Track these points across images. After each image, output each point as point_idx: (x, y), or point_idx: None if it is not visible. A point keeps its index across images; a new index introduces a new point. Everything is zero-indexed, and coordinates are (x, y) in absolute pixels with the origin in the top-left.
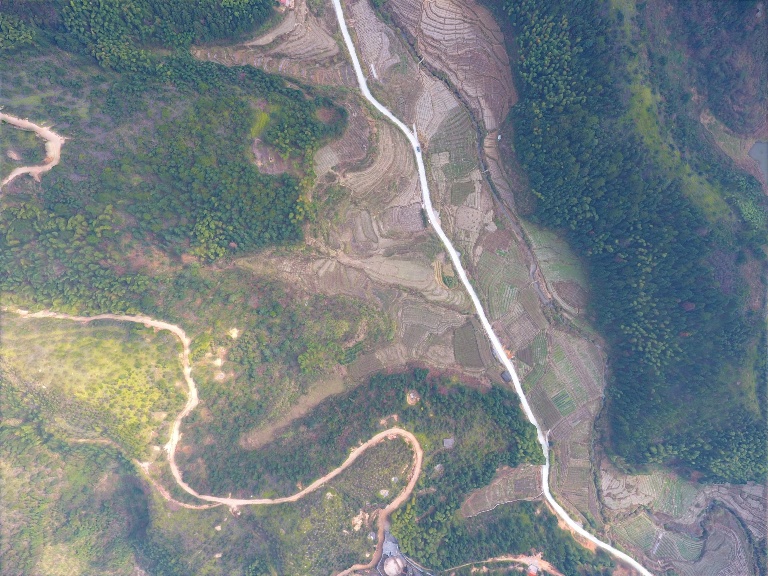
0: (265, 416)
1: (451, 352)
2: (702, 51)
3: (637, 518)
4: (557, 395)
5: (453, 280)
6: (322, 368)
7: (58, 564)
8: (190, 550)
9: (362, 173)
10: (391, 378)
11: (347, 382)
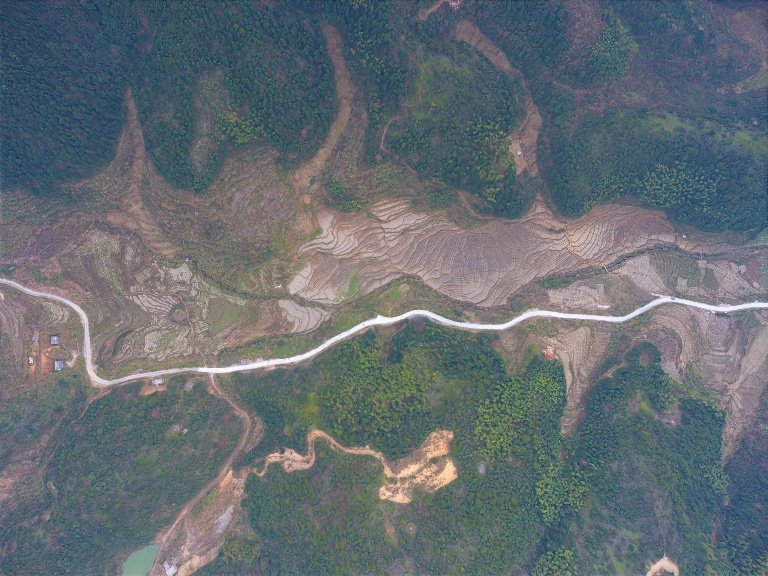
0: None
1: None
2: (703, 76)
3: None
4: None
5: None
6: None
7: None
8: None
9: (683, 348)
10: None
11: None
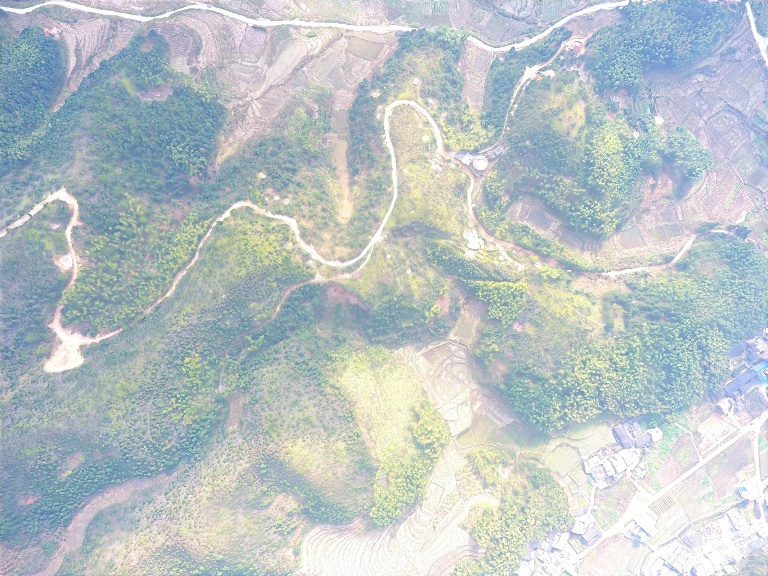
0: (333, 196)
1: (363, 61)
2: None
3: (544, 1)
4: (432, 9)
5: (313, 31)
6: (324, 148)
7: (357, 383)
8: (393, 282)
9: (203, 49)
10: (355, 102)
11: (343, 136)
